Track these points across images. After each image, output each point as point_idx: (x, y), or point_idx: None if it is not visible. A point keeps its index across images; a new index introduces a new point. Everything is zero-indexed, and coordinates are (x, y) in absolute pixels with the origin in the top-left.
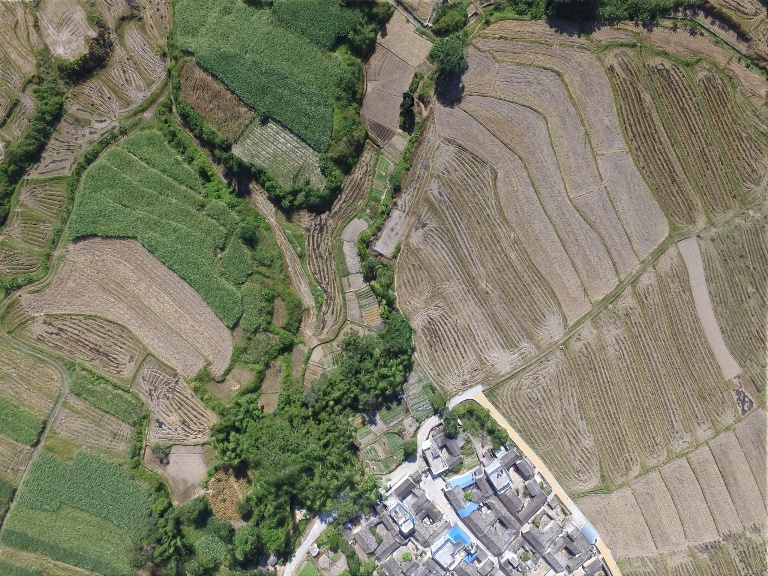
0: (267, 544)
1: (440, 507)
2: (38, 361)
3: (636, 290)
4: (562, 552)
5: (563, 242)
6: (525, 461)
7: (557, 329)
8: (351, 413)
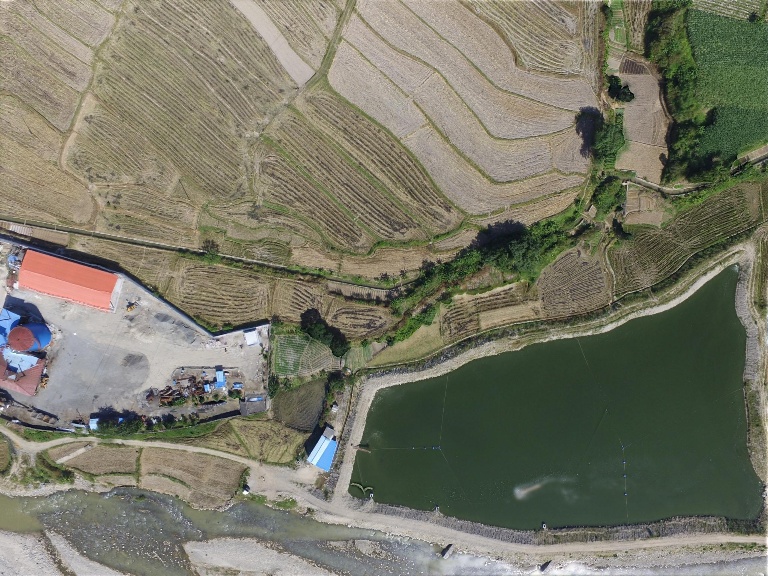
0: None
1: None
2: None
3: (335, 9)
4: None
5: (426, 26)
6: None
7: None
8: None
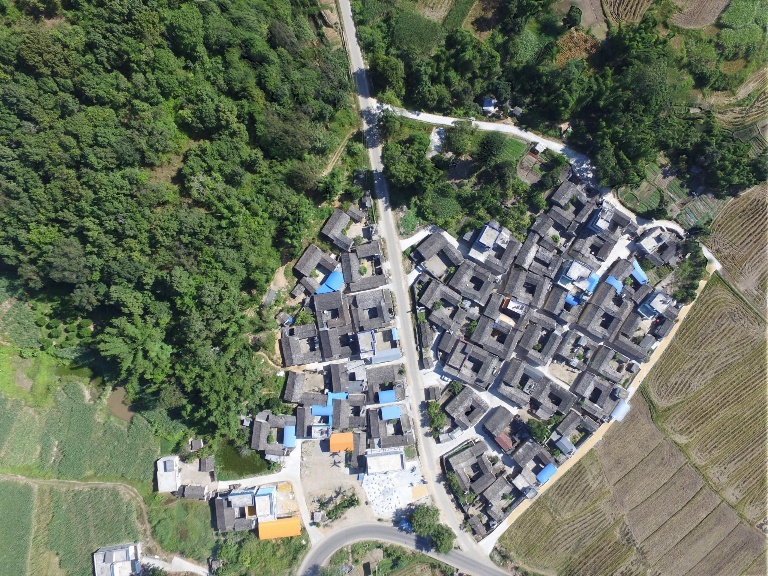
0: (566, 90)
1: None
2: None
3: None
4: None
5: None
6: (673, 326)
7: None
8: (667, 152)
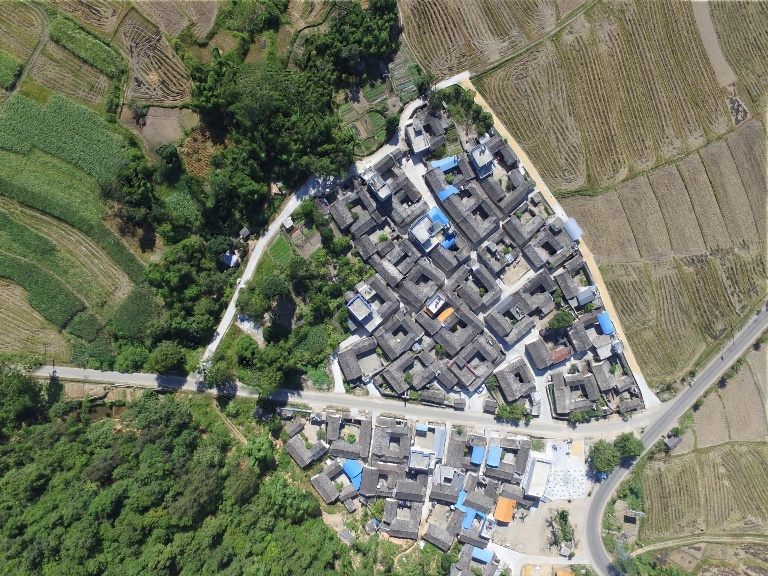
0: (239, 189)
1: (420, 191)
2: (19, 5)
3: None
4: (543, 250)
5: None
6: (509, 147)
7: (549, 20)
8: (334, 89)
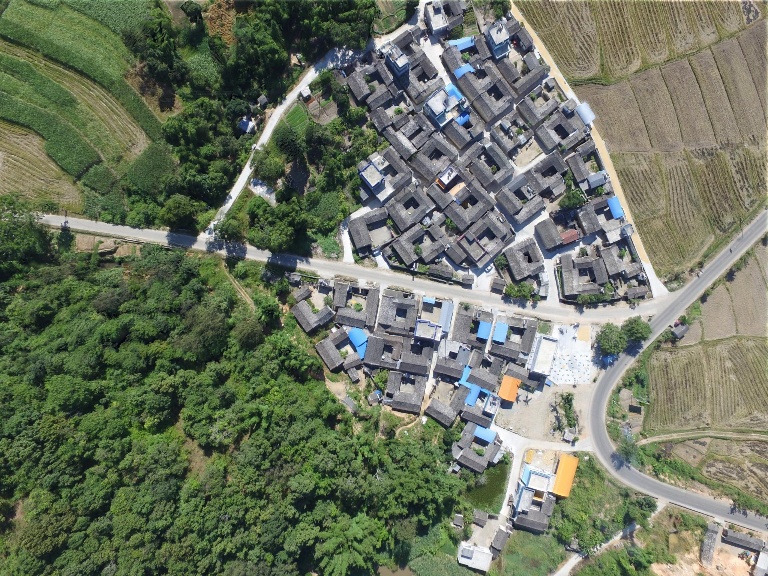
0: (260, 46)
1: None
2: None
3: None
4: None
5: None
6: (526, 30)
7: None
8: None
